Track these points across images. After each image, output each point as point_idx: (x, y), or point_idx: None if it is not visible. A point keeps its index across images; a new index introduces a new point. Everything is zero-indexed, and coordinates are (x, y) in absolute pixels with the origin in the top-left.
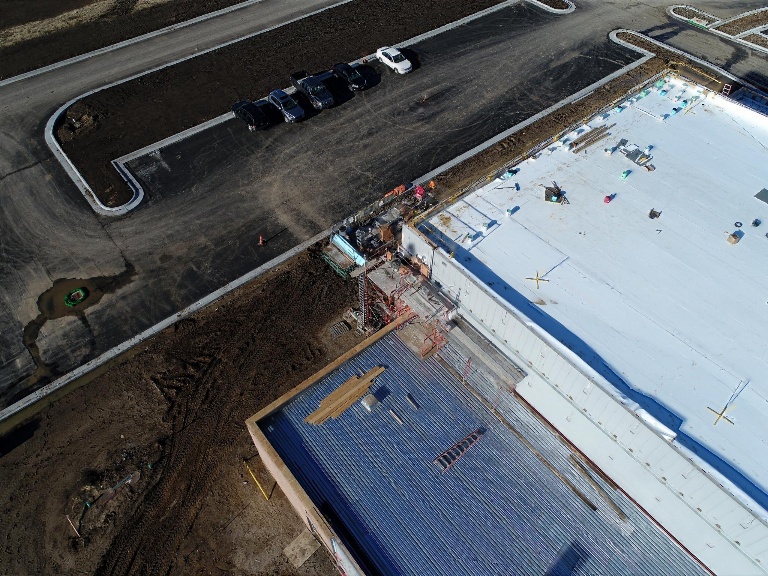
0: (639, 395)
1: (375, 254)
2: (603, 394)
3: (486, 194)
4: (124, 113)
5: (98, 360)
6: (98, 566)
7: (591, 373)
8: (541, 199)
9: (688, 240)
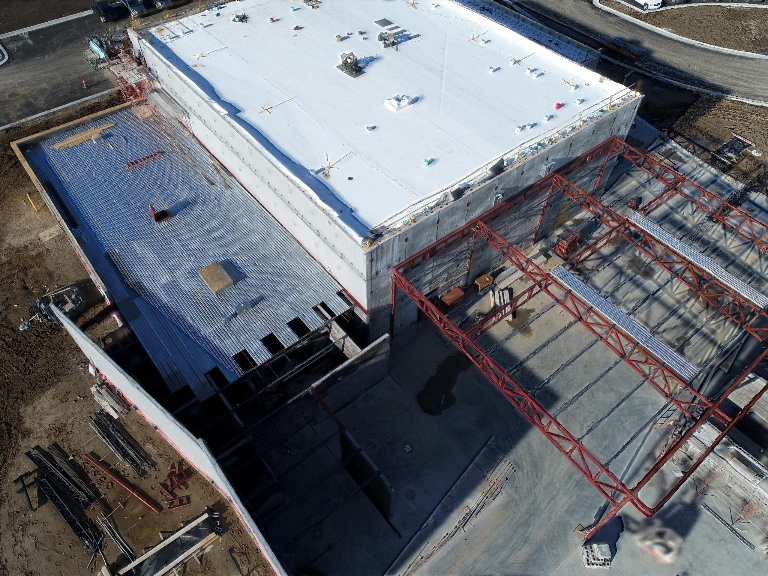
0: (224, 102)
1: (118, 56)
2: (200, 99)
3: (195, 18)
4: (8, 9)
5: None
6: None
7: (197, 90)
8: (230, 21)
9: (310, 40)
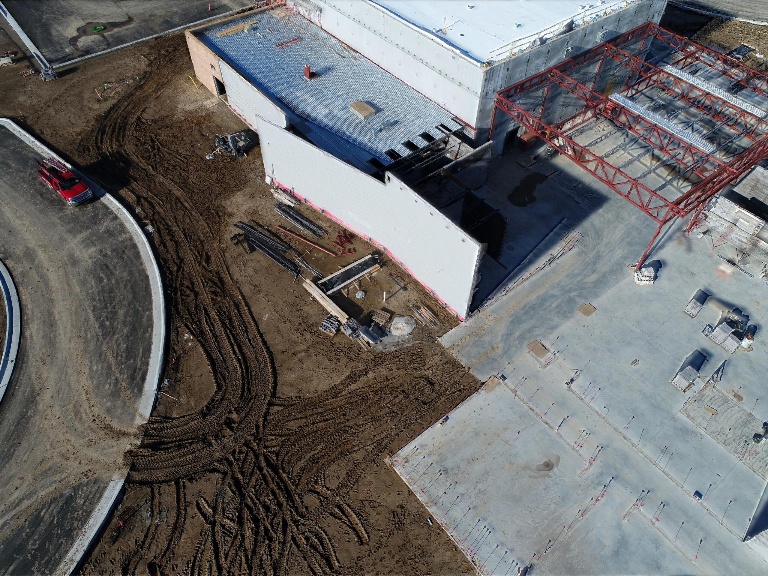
0: None
1: None
2: None
3: None
4: None
5: (111, 49)
6: (110, 107)
7: None
8: None
9: None
